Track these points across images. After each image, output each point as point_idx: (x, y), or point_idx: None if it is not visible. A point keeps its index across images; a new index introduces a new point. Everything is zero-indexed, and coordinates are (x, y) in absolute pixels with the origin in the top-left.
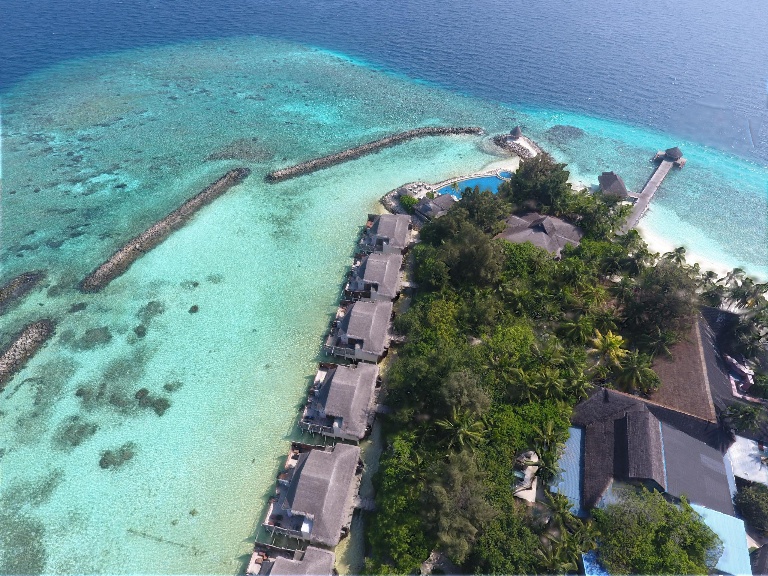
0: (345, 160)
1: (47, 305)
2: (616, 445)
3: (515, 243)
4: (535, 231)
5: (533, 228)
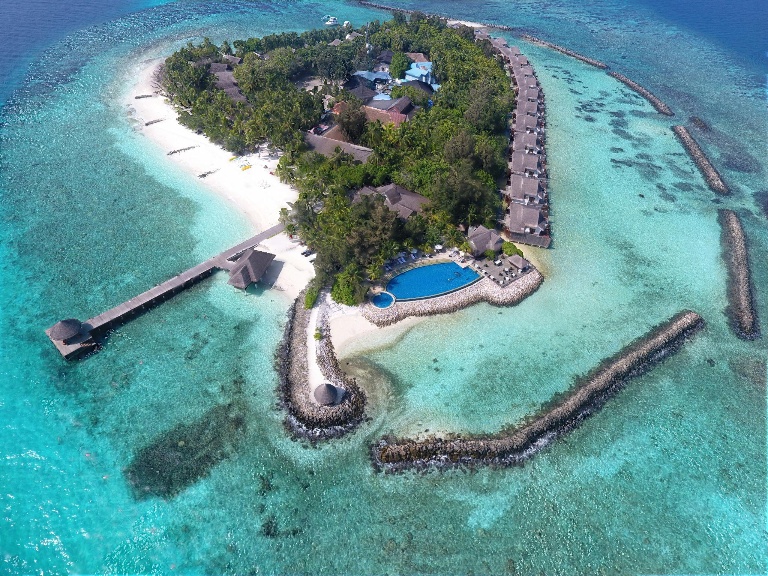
0: (619, 355)
1: (738, 204)
2: (408, 112)
3: (430, 165)
4: (399, 193)
5: (400, 194)
